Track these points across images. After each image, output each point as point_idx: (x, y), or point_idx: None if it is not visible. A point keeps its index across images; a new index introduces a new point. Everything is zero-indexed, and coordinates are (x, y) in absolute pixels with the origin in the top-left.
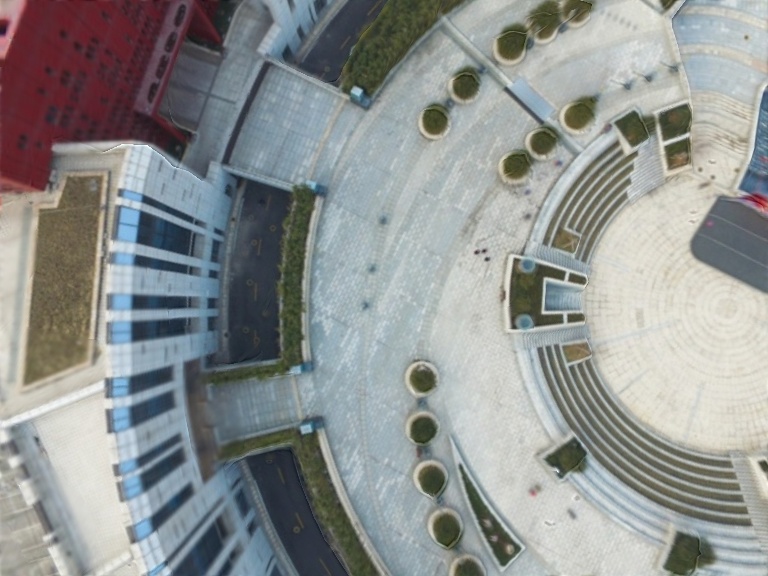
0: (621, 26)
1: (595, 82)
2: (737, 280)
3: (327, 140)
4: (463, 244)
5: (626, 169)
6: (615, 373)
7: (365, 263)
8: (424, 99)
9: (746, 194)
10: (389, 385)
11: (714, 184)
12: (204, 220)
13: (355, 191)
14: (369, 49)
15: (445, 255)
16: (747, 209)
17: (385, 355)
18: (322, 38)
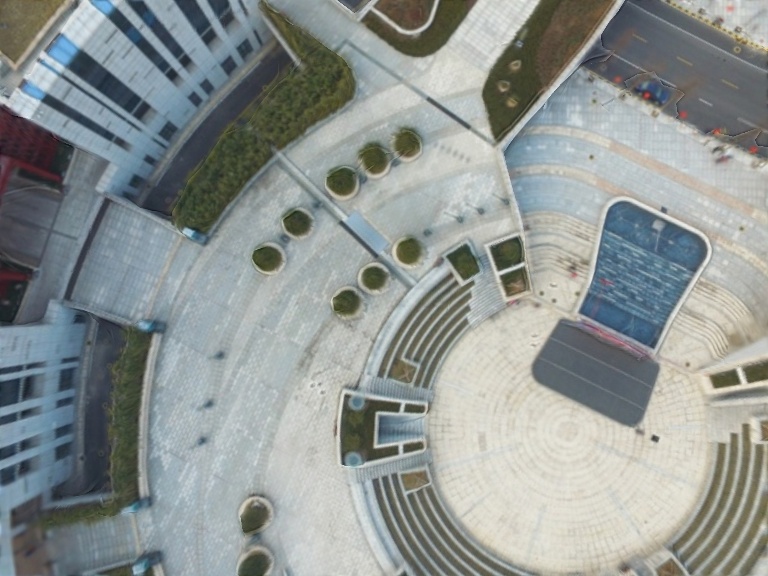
0: (454, 158)
1: (429, 215)
2: (577, 403)
3: (166, 275)
4: (299, 378)
5: (464, 297)
6: (458, 497)
7: (203, 398)
8: (261, 234)
9: (585, 318)
10: (225, 519)
11: (555, 307)
12: (42, 360)
13: (193, 326)
14: (196, 194)
15: (281, 389)
16: (585, 334)
17: (222, 489)
18: (175, 161)
